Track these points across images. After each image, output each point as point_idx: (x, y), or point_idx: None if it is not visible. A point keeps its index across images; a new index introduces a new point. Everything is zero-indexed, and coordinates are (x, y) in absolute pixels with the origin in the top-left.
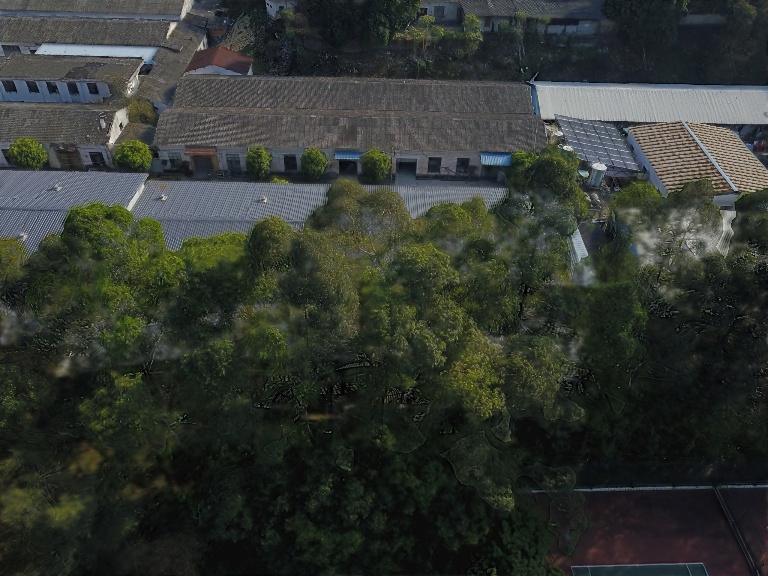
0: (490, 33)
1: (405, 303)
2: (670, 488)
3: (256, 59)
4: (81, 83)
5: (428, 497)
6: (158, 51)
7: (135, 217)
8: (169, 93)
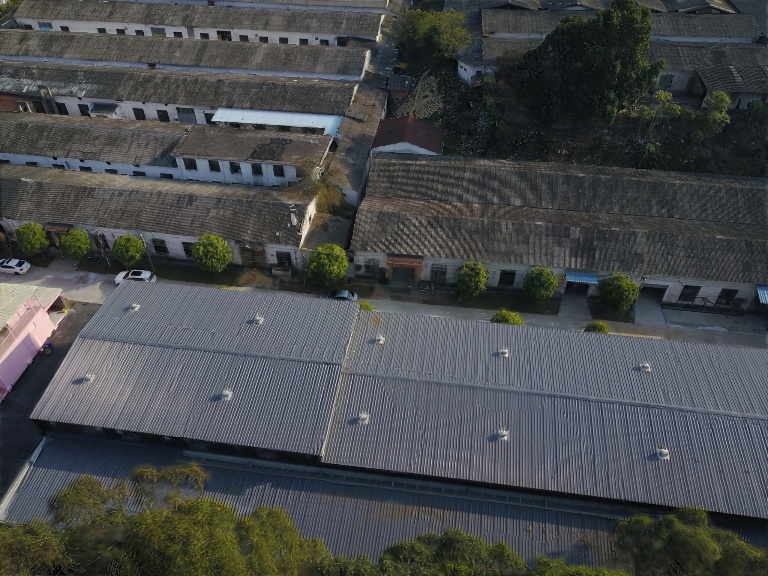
0: (733, 111)
1: None
2: None
3: (446, 130)
4: (267, 165)
5: None
6: (342, 122)
7: (352, 370)
8: (358, 176)
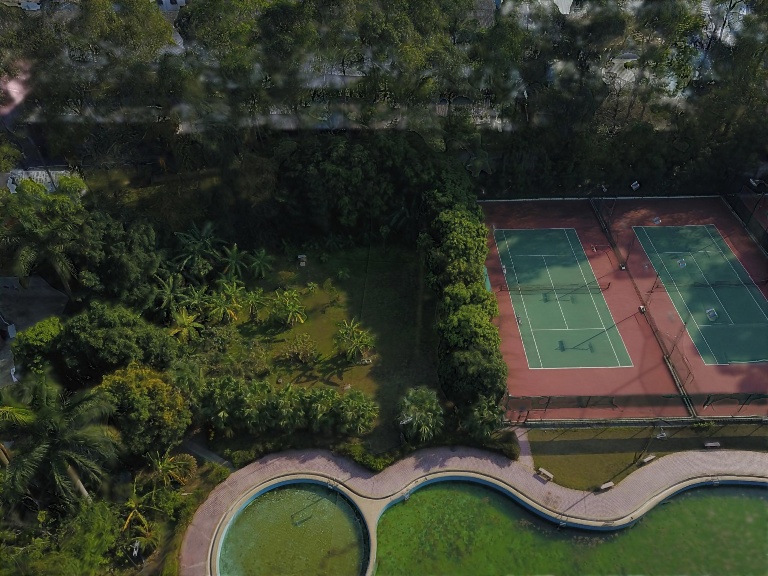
0: None
1: (379, 11)
2: (561, 199)
3: None
4: None
5: (400, 157)
6: None
7: None
8: None
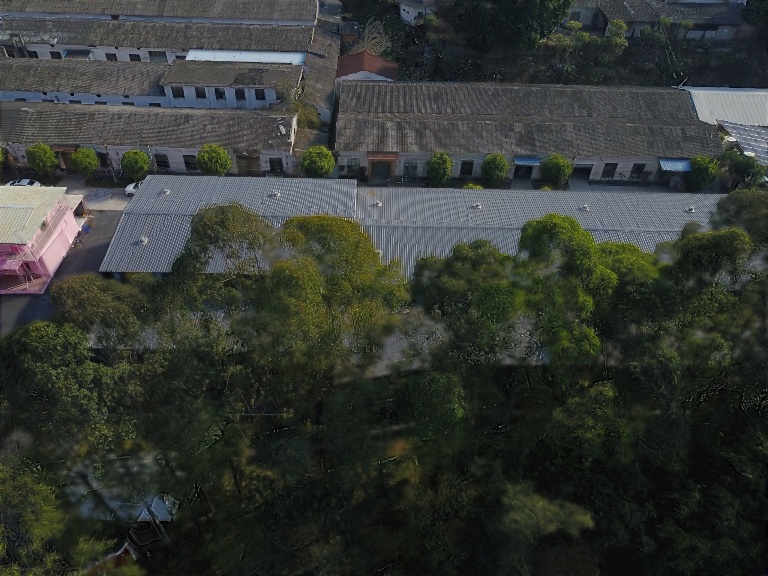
0: (630, 38)
1: None
2: None
3: None
4: (249, 89)
5: None
6: (307, 57)
7: (362, 223)
8: (329, 99)
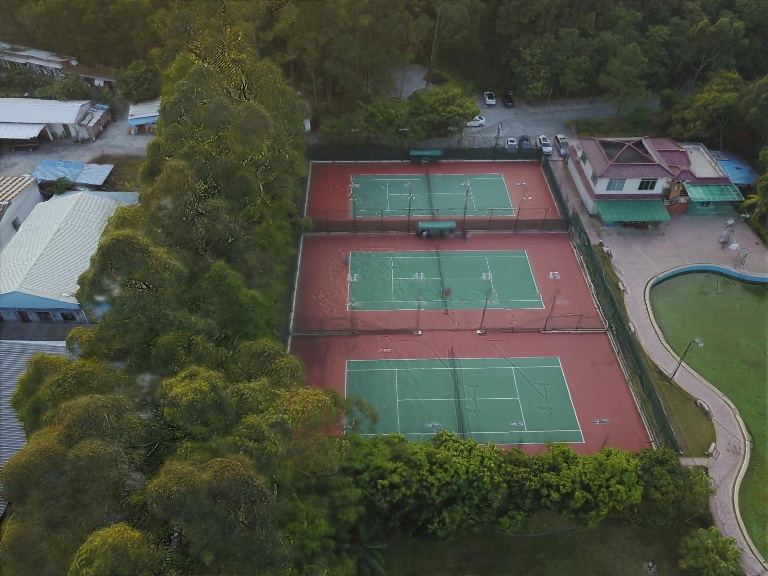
0: None
1: (236, 423)
2: None
3: None
4: None
5: None
6: None
7: None
8: None
